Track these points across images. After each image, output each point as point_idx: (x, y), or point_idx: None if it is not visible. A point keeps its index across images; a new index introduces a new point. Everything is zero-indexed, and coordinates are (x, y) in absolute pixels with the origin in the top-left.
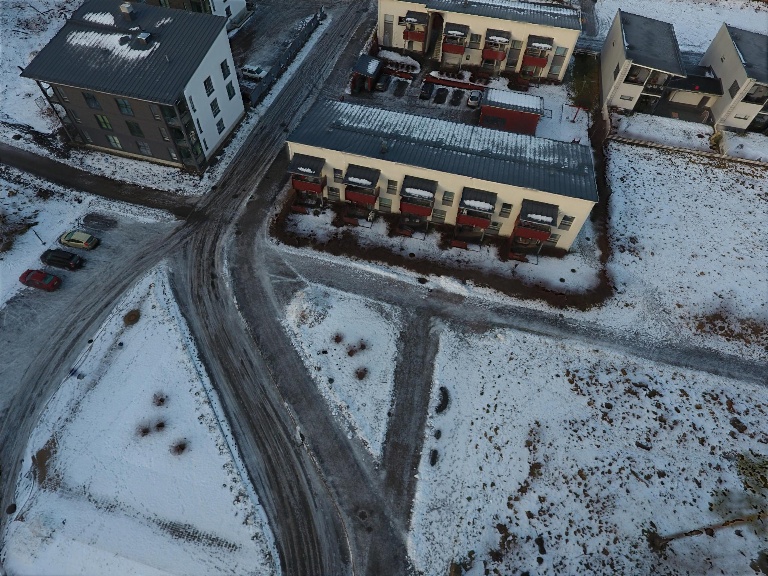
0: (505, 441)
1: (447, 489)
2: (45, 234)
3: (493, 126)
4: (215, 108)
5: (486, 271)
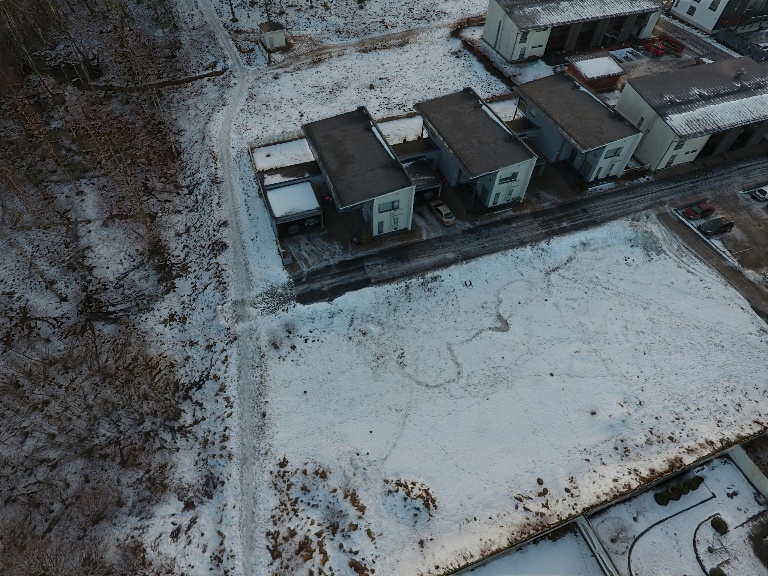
0: None
1: None
2: None
3: None
4: None
5: None
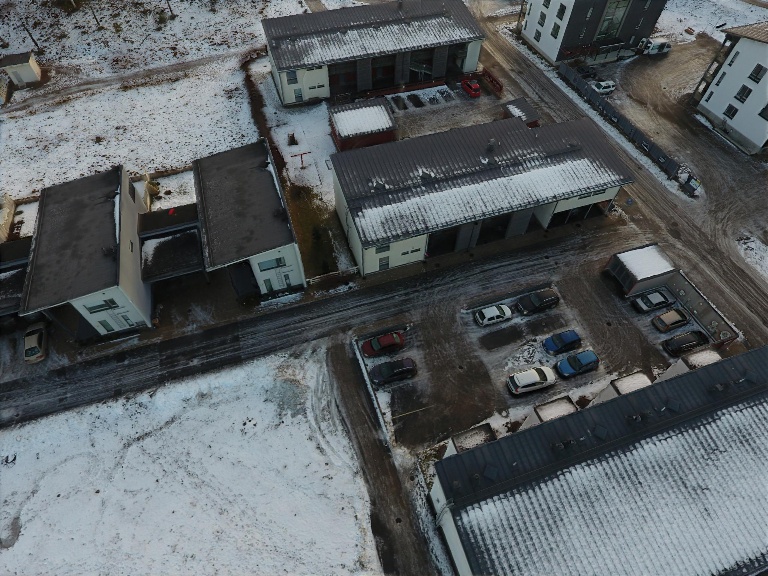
0: (275, 13)
1: None
2: None
3: None
4: (544, 22)
5: None
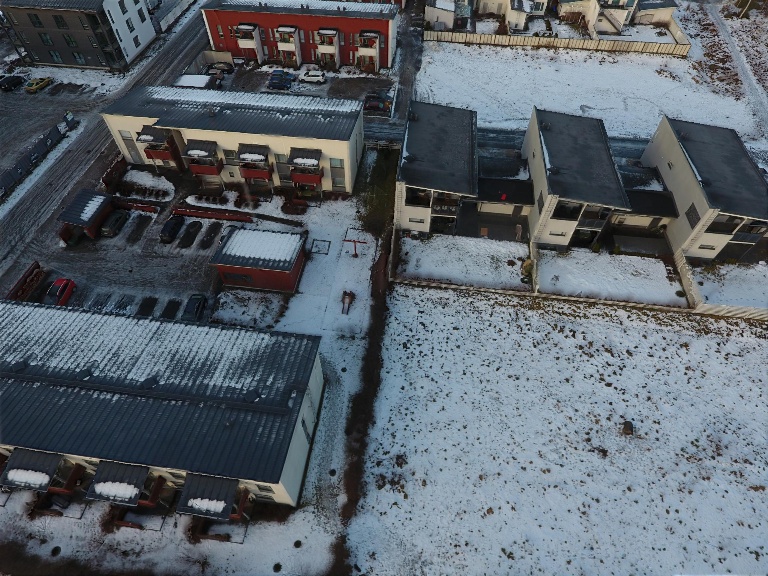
0: None
1: None
2: None
3: (241, 282)
4: None
5: (161, 570)
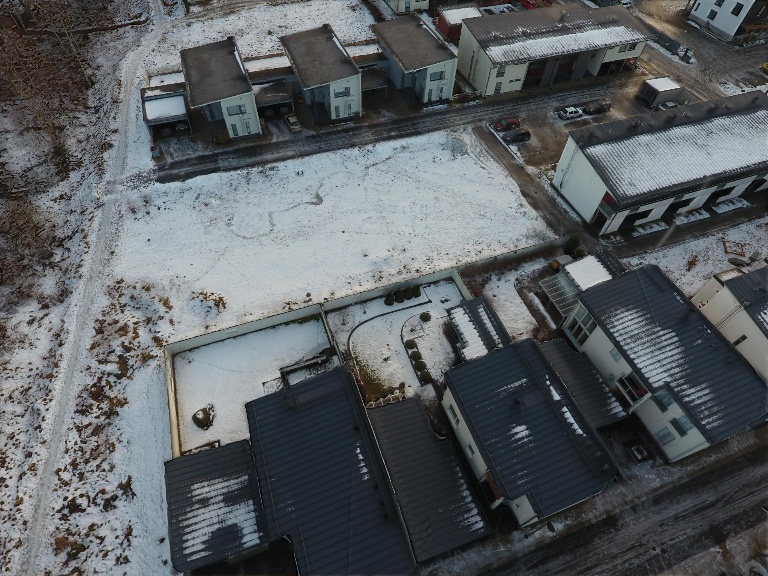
0: None
1: None
2: None
3: None
4: None
5: None
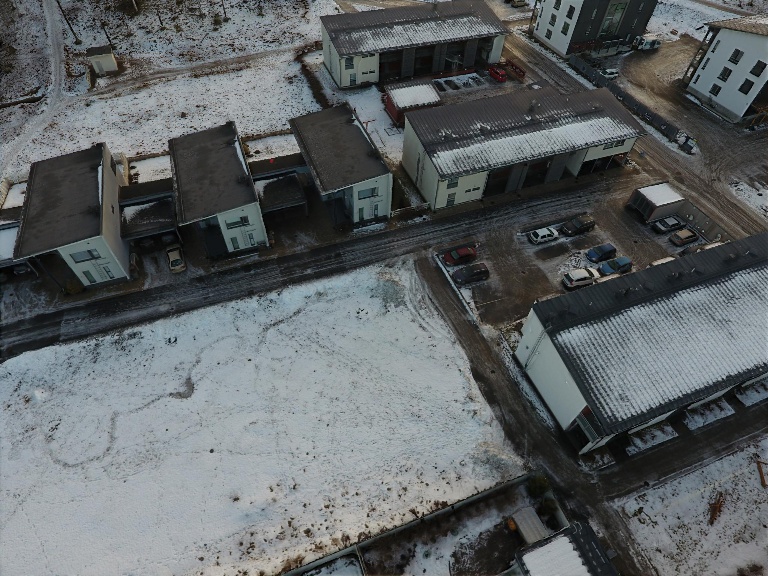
0: None
1: (328, 6)
2: (534, 2)
3: None
4: None
5: None
